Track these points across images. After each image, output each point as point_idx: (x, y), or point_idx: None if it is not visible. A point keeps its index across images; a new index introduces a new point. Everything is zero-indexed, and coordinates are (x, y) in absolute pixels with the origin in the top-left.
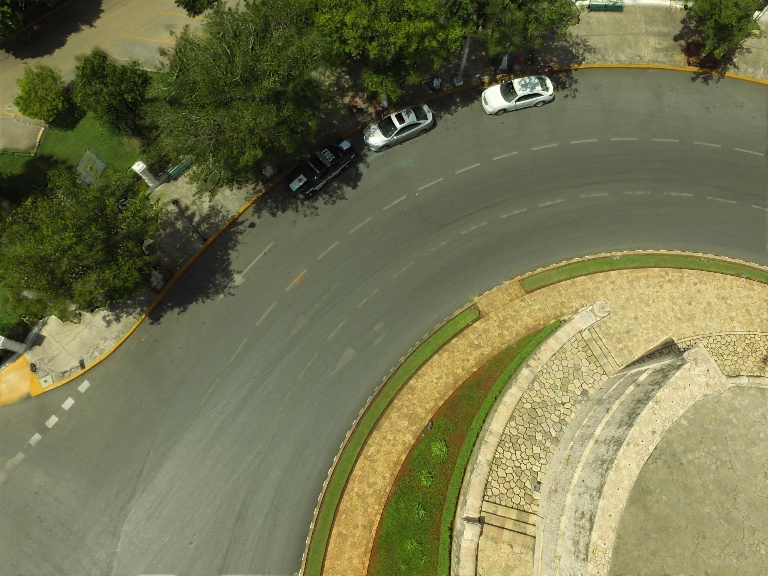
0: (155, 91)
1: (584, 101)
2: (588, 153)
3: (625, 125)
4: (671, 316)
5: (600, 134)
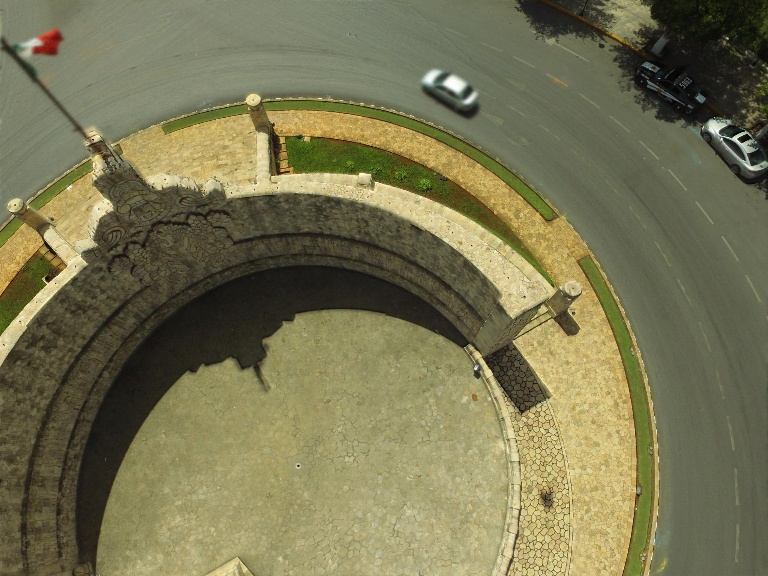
0: None
1: None
2: (759, 334)
3: None
4: (576, 399)
5: None
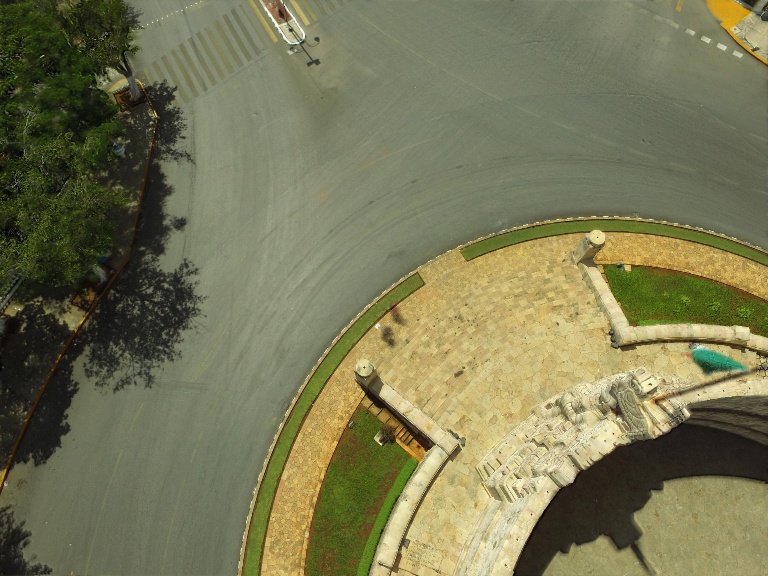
0: None
1: None
2: None
3: None
4: None
5: None
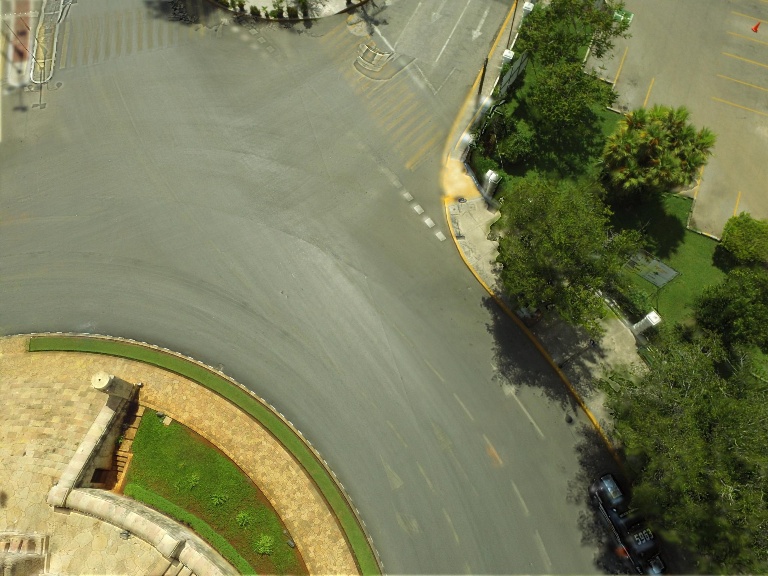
0: (739, 350)
1: None
2: None
3: None
4: None
5: None
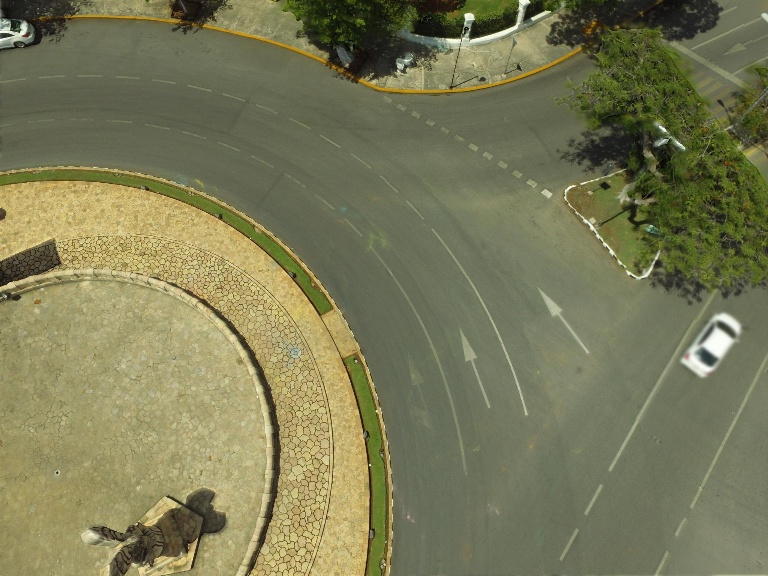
0: None
1: (66, 44)
2: (51, 86)
3: (96, 65)
4: (62, 221)
5: (69, 71)
